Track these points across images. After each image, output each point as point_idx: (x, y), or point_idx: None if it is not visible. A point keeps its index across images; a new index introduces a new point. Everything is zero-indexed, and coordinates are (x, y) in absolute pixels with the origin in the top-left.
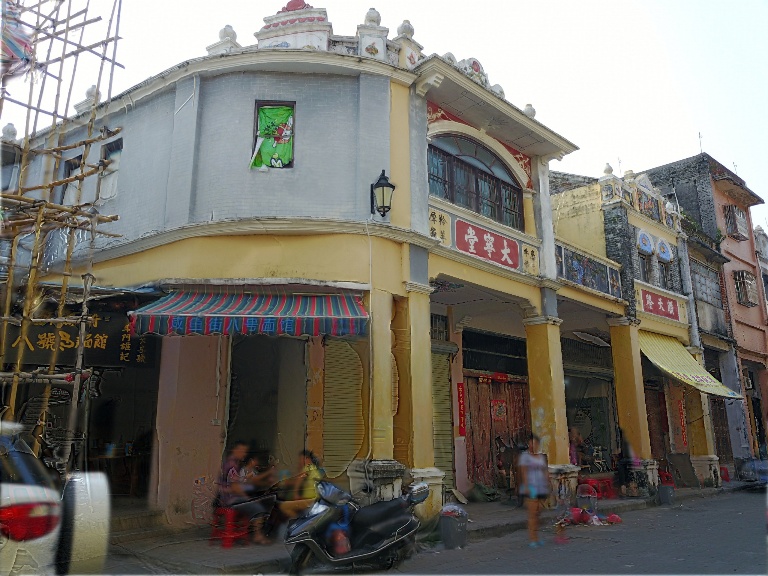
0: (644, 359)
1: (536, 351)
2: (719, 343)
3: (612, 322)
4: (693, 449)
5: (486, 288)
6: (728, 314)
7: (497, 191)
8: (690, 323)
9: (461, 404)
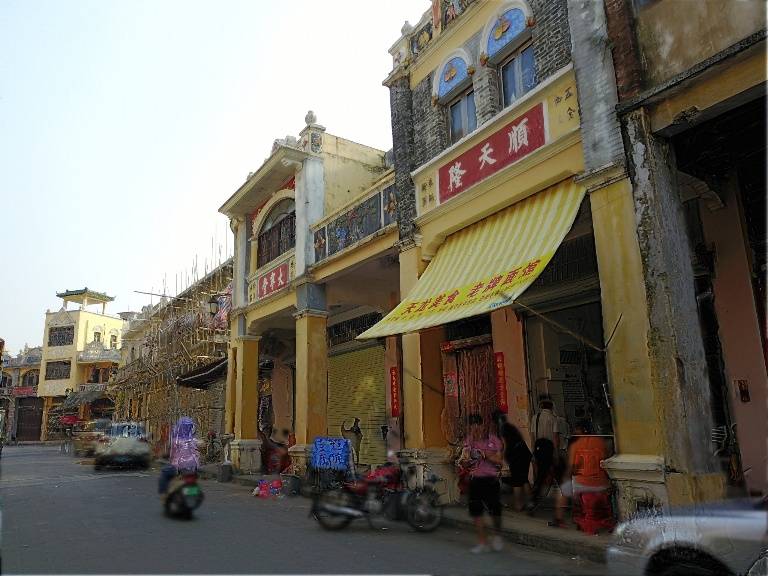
0: None
1: None
2: None
3: None
4: None
5: (274, 313)
6: None
7: None
8: None
9: (394, 387)
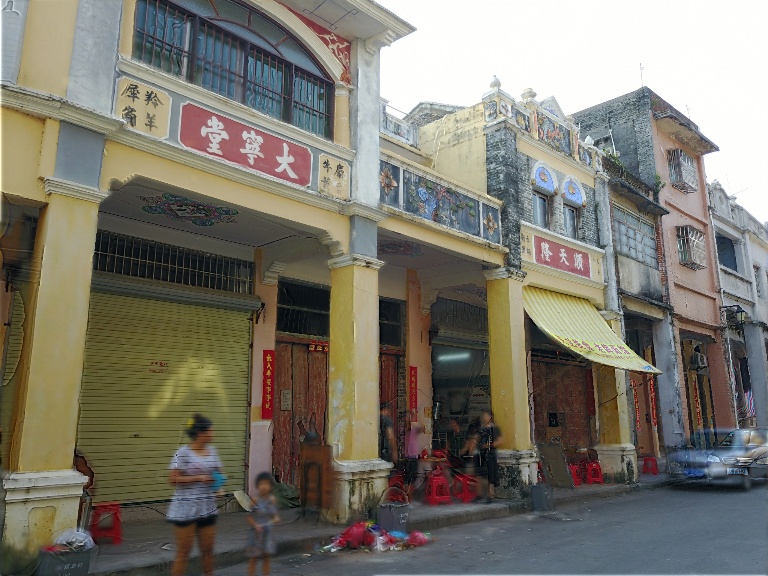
0: (528, 322)
1: (340, 303)
2: (650, 309)
3: (489, 275)
4: (604, 436)
5: (242, 207)
6: (664, 275)
7: (288, 80)
8: (606, 282)
9: (268, 378)
